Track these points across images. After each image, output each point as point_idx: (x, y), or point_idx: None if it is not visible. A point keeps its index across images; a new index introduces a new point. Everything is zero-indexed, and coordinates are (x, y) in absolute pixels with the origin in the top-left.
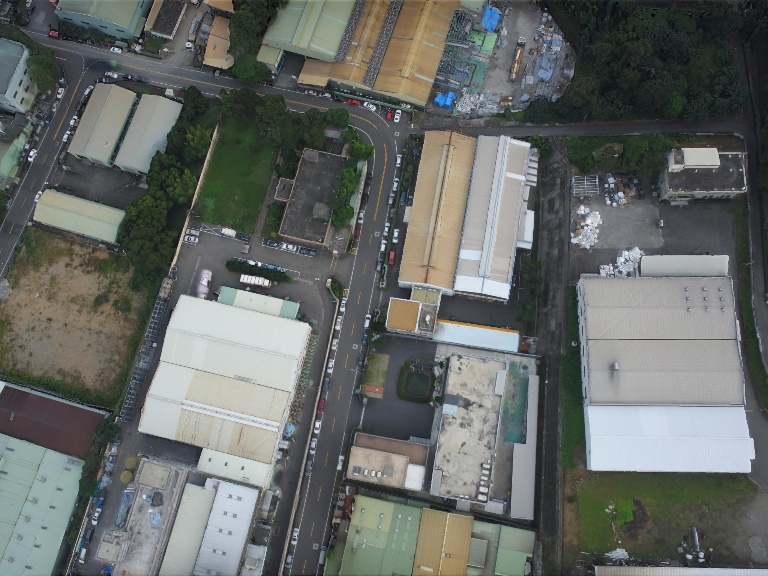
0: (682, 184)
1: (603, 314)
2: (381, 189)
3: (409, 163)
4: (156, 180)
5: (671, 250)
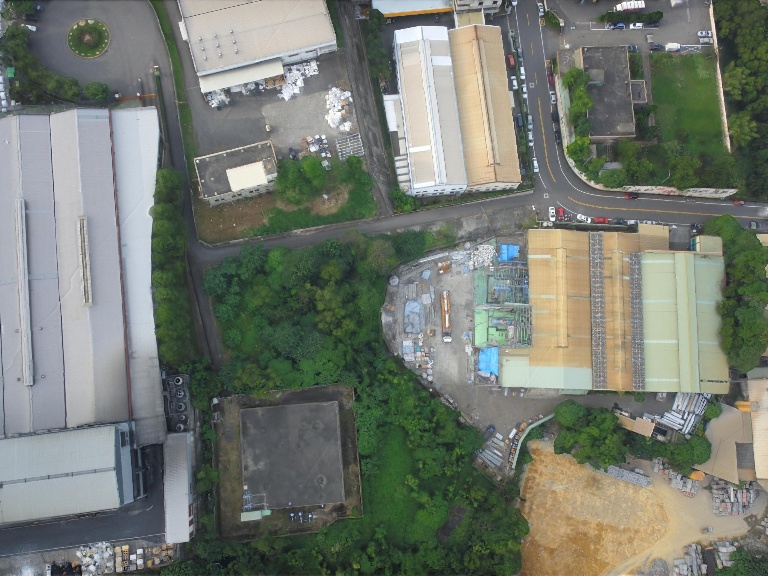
0: (258, 154)
1: (310, 10)
2: (543, 132)
3: (526, 155)
4: (765, 79)
5: (254, 105)
